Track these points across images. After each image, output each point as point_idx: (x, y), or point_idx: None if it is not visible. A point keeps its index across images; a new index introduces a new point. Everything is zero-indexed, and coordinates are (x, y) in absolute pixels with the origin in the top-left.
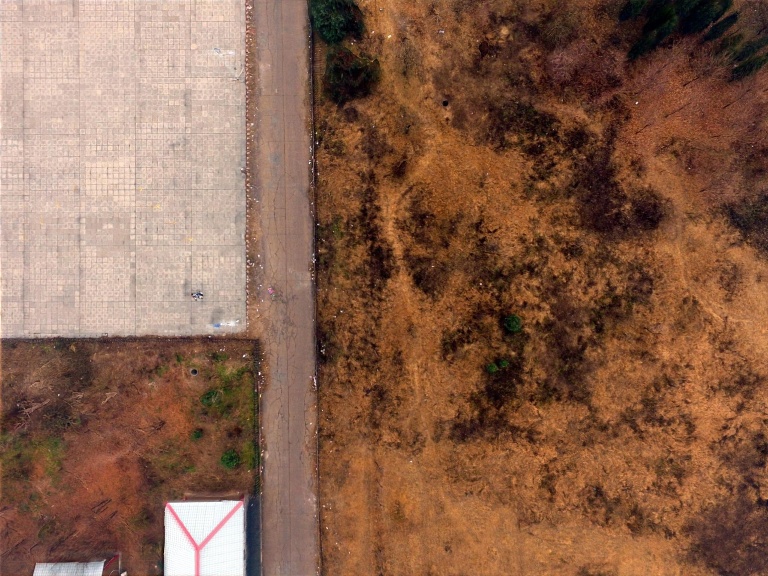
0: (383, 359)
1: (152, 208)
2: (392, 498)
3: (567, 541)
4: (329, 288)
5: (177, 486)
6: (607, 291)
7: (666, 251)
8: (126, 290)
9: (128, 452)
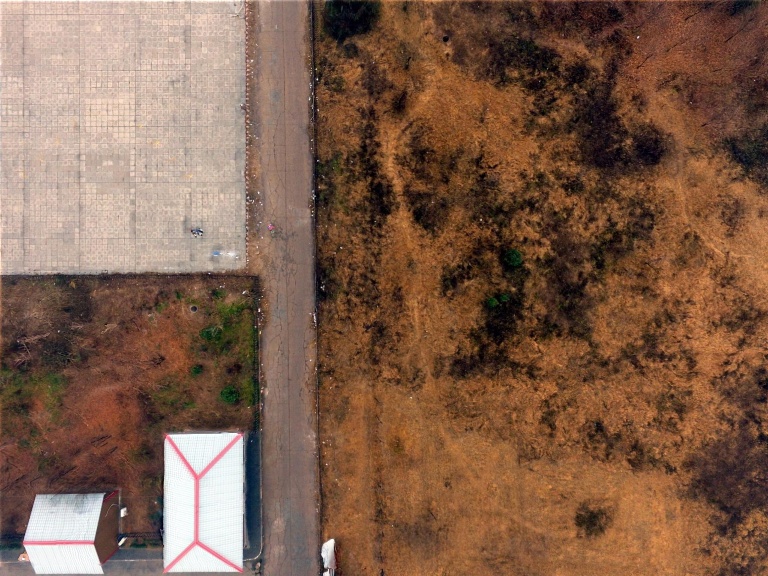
0: (383, 295)
1: (152, 145)
2: (392, 434)
3: (567, 477)
4: (329, 224)
5: (177, 422)
6: (608, 227)
7: (667, 186)
8: (126, 227)
9: (128, 389)
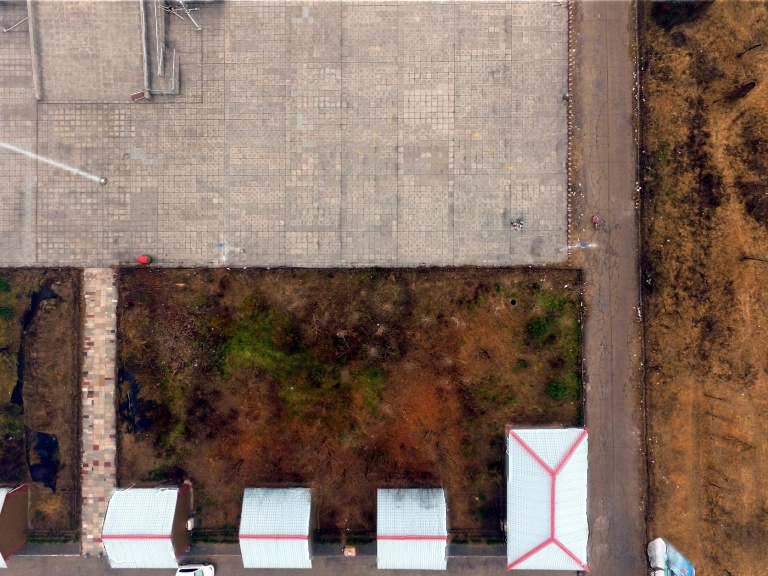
0: (713, 289)
1: (471, 136)
2: (723, 431)
3: None
4: (655, 217)
5: (498, 418)
6: None
7: None
8: (444, 219)
9: (447, 383)
